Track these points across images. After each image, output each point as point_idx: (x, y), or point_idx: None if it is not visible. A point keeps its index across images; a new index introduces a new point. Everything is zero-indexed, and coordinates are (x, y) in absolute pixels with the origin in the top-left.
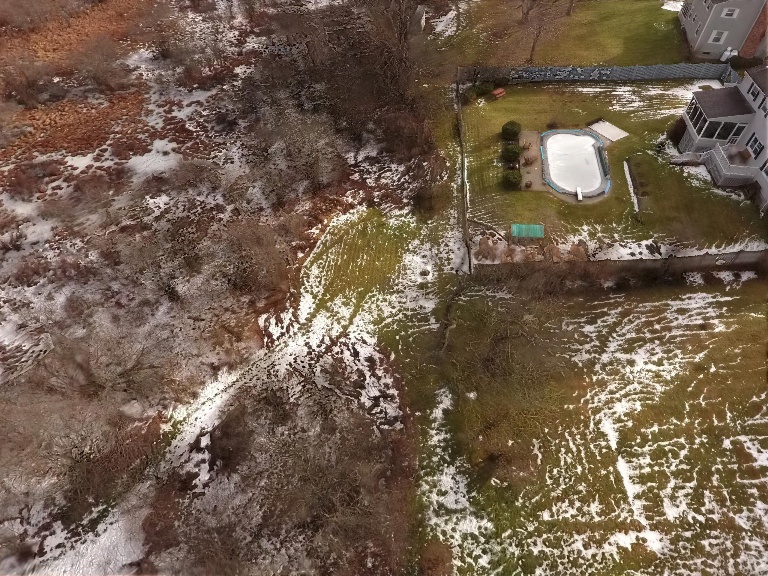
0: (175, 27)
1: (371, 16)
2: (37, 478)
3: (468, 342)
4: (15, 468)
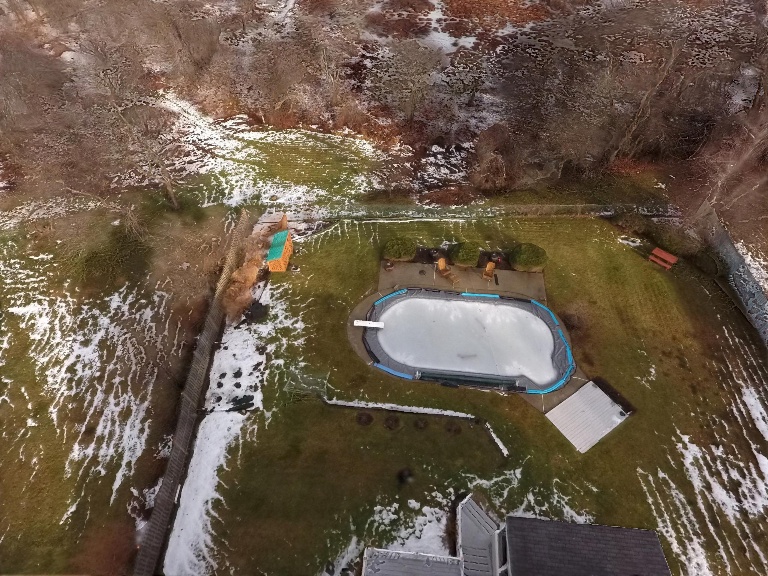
0: (702, 5)
1: (767, 81)
2: (148, 62)
3: (172, 221)
4: (158, 55)
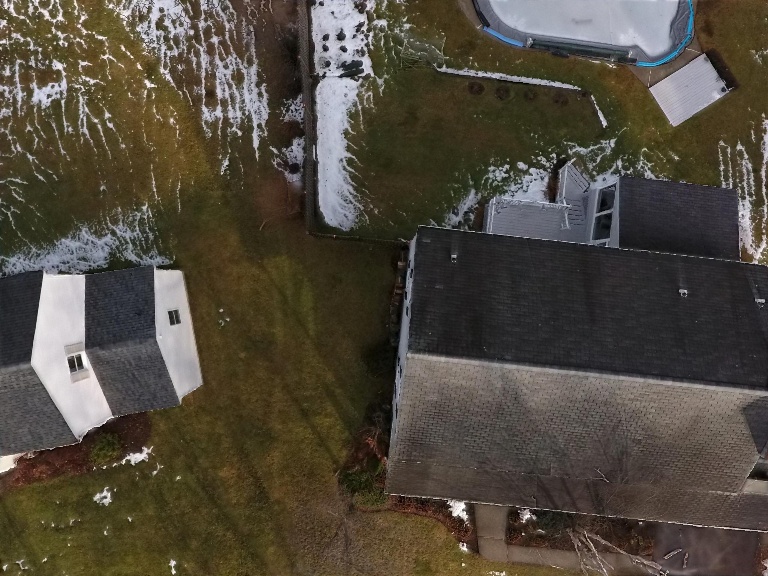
0: None
1: None
2: None
3: None
4: None
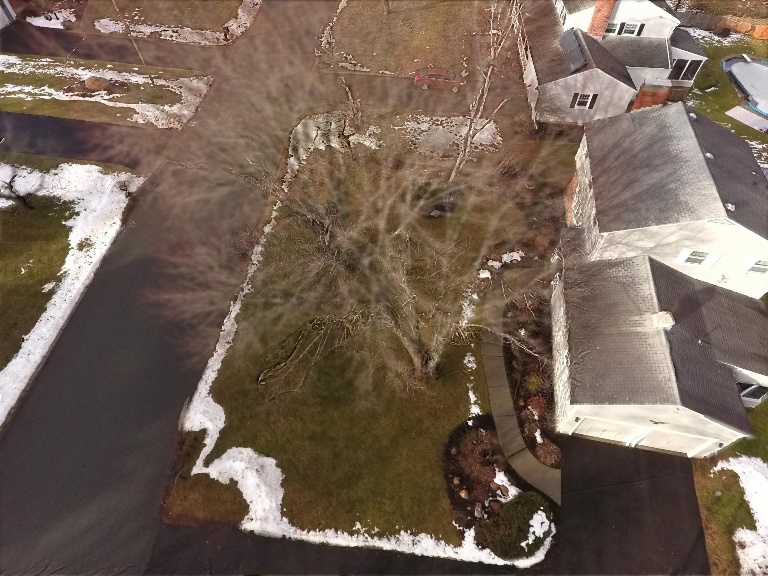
0: None
1: None
2: None
3: None
4: None
